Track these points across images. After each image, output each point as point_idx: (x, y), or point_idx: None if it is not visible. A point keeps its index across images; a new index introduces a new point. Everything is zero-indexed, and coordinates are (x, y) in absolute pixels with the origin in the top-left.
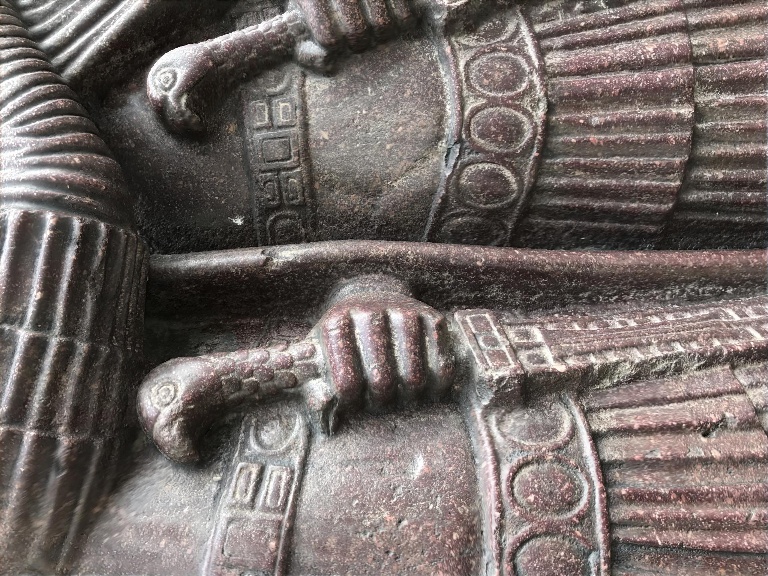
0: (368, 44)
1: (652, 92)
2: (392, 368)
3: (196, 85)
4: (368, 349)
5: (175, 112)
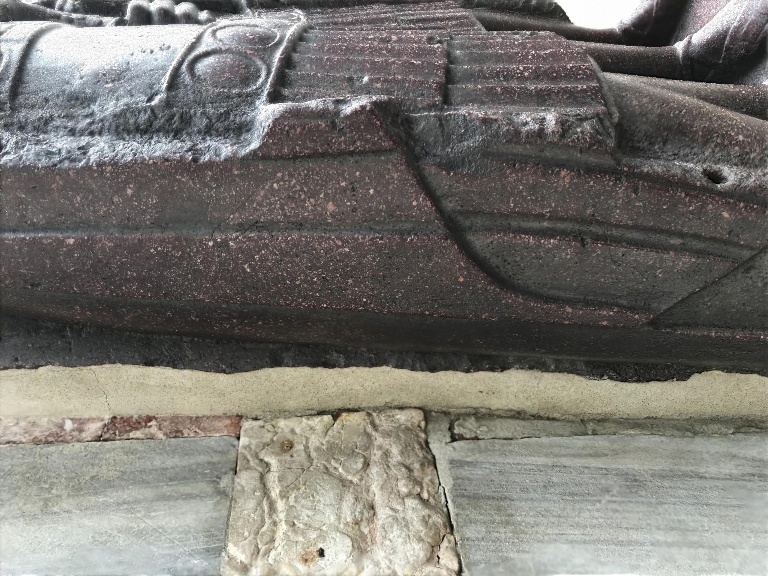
0: (200, 8)
1: (371, 20)
2: (170, 8)
3: (87, 1)
4: (155, 2)
5: (69, 5)
